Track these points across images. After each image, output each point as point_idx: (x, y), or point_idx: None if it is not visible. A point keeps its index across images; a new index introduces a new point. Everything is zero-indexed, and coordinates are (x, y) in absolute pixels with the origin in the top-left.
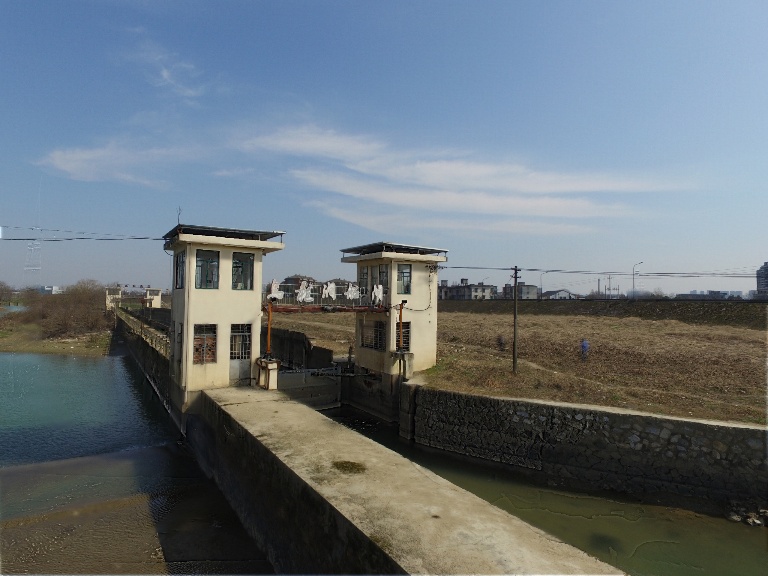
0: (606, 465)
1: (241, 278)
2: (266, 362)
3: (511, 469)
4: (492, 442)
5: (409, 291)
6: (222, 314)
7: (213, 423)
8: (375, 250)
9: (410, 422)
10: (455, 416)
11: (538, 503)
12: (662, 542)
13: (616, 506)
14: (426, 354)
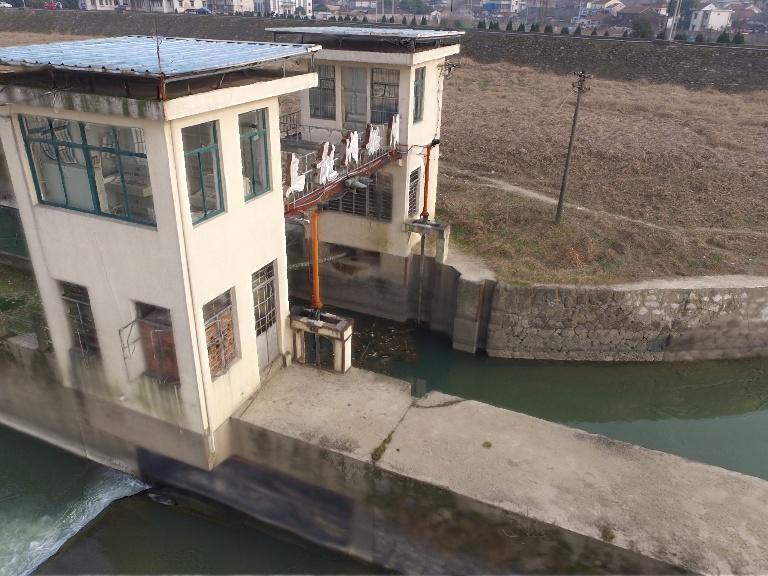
0: (733, 343)
1: (184, 147)
2: (340, 331)
3: (627, 367)
4: (607, 341)
5: (420, 114)
6: (238, 262)
7: (332, 483)
8: (365, 38)
9: (477, 331)
10: (559, 318)
11: (650, 393)
12: (758, 397)
13: (731, 378)
14: (429, 209)
